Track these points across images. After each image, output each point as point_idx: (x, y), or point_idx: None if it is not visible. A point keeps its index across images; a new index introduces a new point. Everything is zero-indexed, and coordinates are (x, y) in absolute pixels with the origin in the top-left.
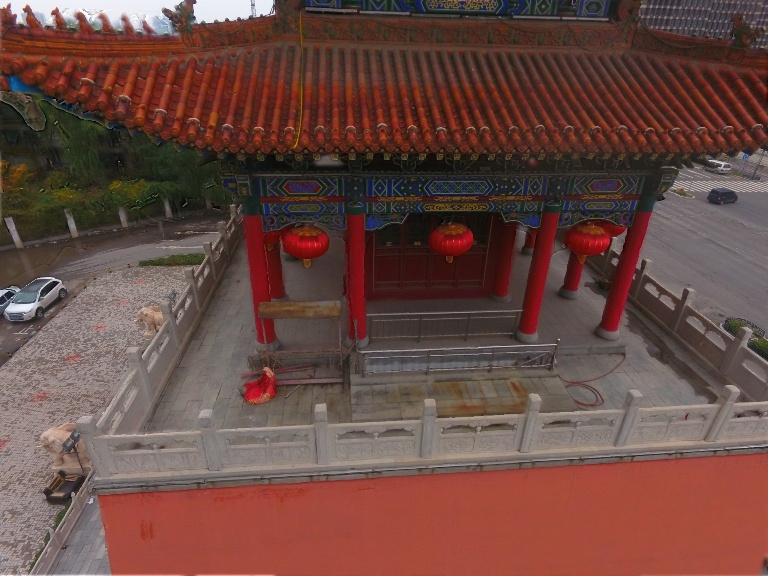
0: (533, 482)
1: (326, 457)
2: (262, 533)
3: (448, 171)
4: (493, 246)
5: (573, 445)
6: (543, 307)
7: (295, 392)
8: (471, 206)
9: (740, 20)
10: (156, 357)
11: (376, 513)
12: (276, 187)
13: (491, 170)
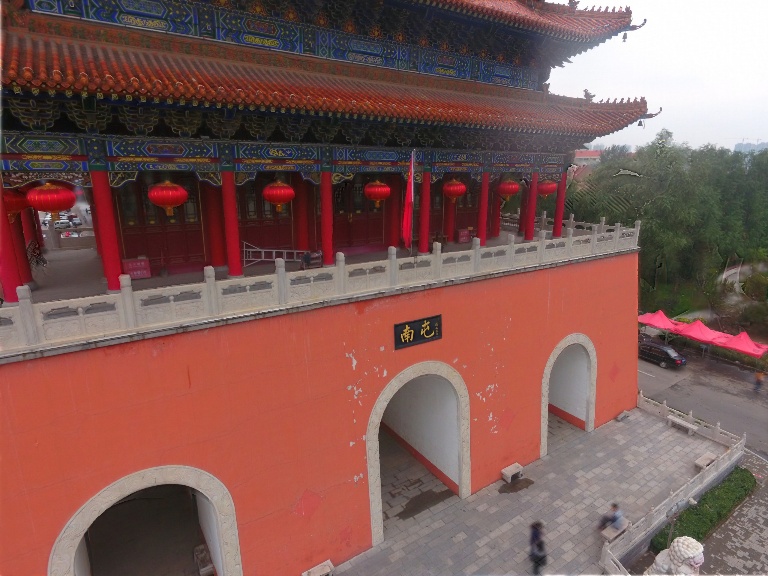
0: None
1: None
2: None
3: None
4: None
5: None
6: (88, 291)
7: None
8: None
9: None
10: None
11: None
12: None
13: None
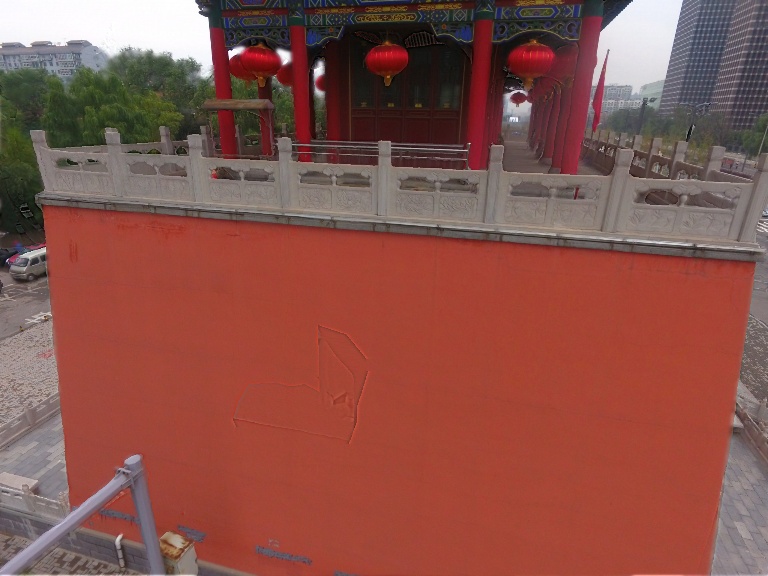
0: (391, 254)
1: (202, 195)
2: (154, 274)
3: None
4: (466, 109)
5: (436, 216)
6: None
7: None
8: (399, 16)
9: None
10: None
11: (244, 268)
12: None
13: None
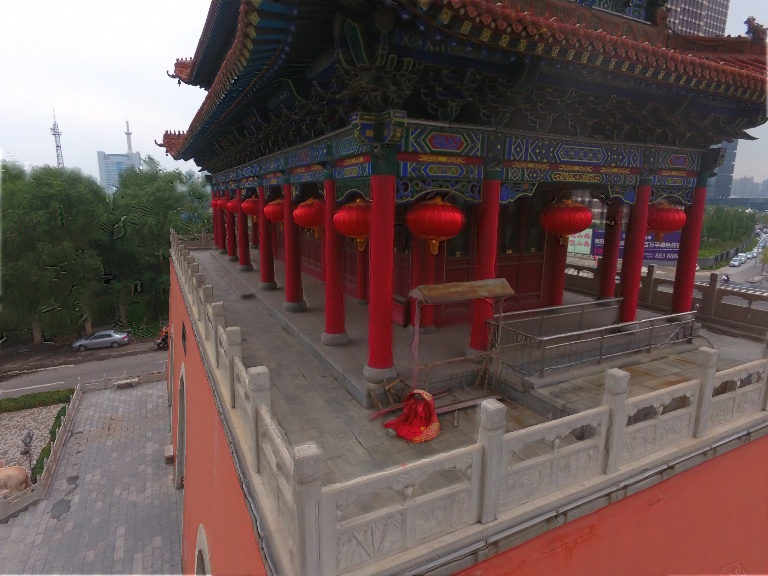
0: None
1: (615, 460)
2: None
3: (573, 136)
4: (549, 253)
5: None
6: None
7: (460, 419)
8: (589, 176)
9: (754, 21)
10: (248, 404)
11: (662, 543)
12: (419, 140)
13: (604, 138)
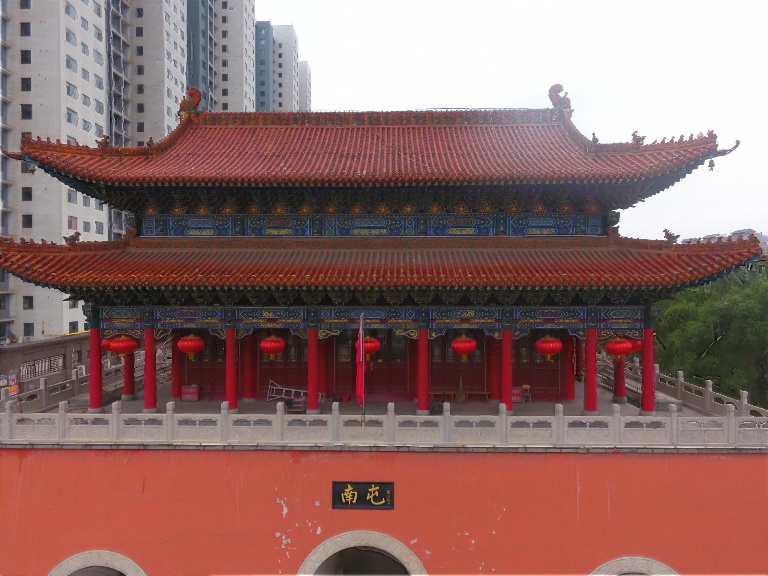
0: None
1: None
2: None
3: None
4: None
5: None
6: None
7: None
8: None
9: (76, 234)
10: None
11: None
12: None
13: None
